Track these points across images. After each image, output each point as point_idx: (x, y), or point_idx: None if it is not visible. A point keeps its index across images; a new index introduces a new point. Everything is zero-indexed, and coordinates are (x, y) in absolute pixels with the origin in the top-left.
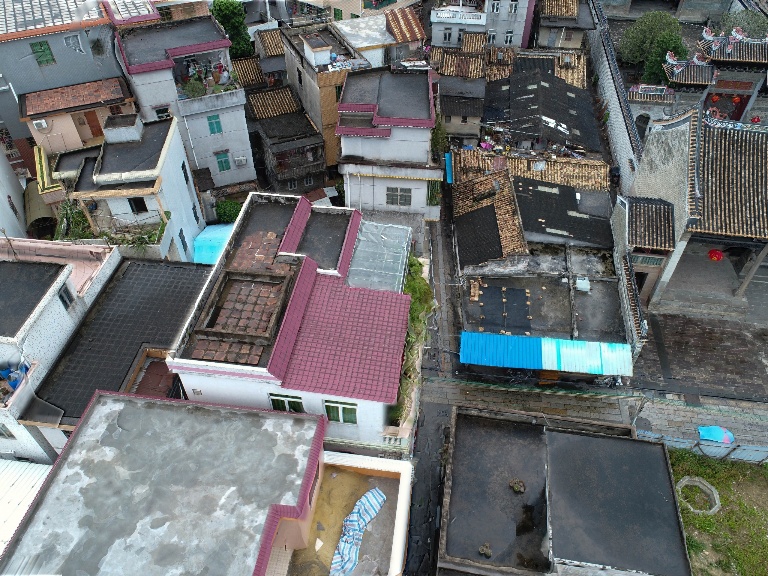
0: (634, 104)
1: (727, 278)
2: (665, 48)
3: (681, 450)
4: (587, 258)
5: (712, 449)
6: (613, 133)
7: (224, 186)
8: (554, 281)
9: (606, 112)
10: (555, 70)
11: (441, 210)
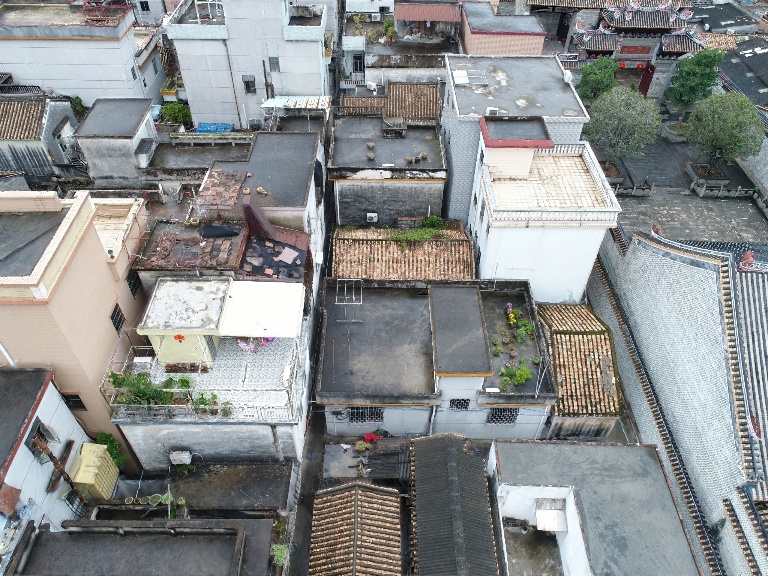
0: None
1: None
2: None
3: None
4: None
5: None
6: None
7: None
8: None
9: None
10: None
11: None
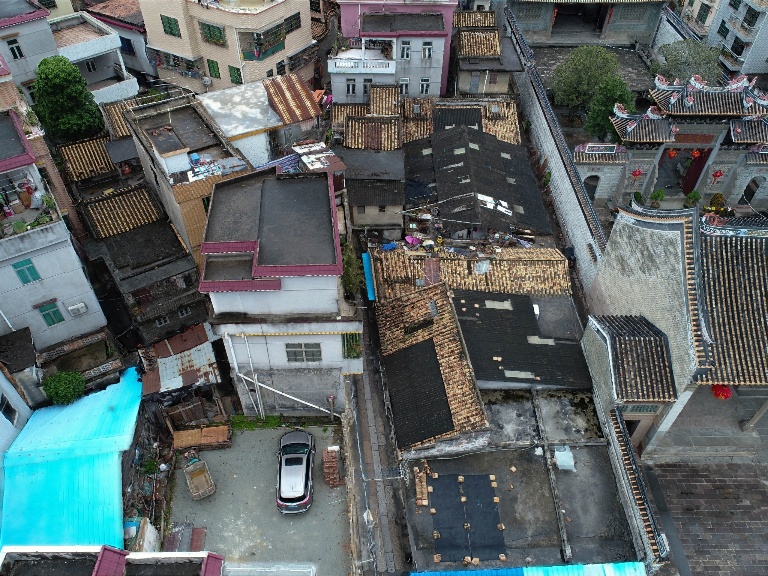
0: (581, 165)
1: (728, 402)
2: (609, 96)
3: None
4: (561, 408)
5: None
6: (559, 200)
7: (58, 344)
8: (525, 455)
9: (547, 171)
10: (482, 123)
11: (364, 330)
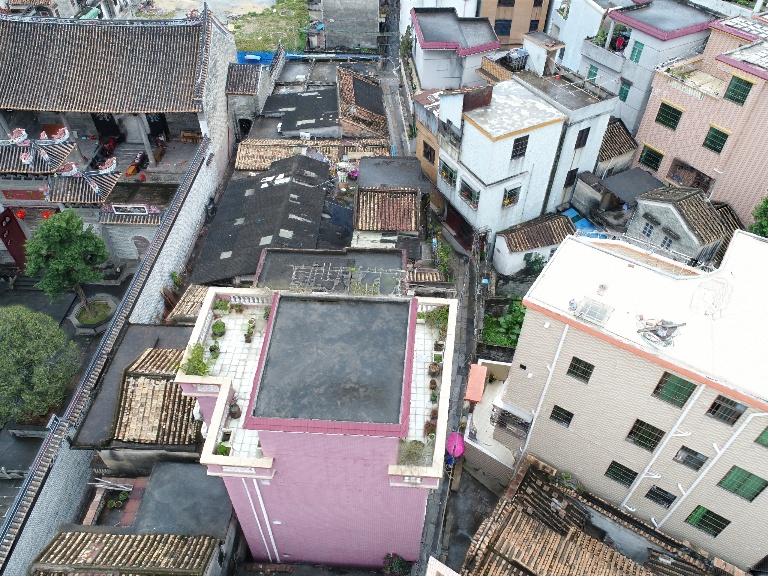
0: None
1: None
2: None
3: None
4: None
5: None
6: None
7: None
8: None
9: None
10: None
11: None
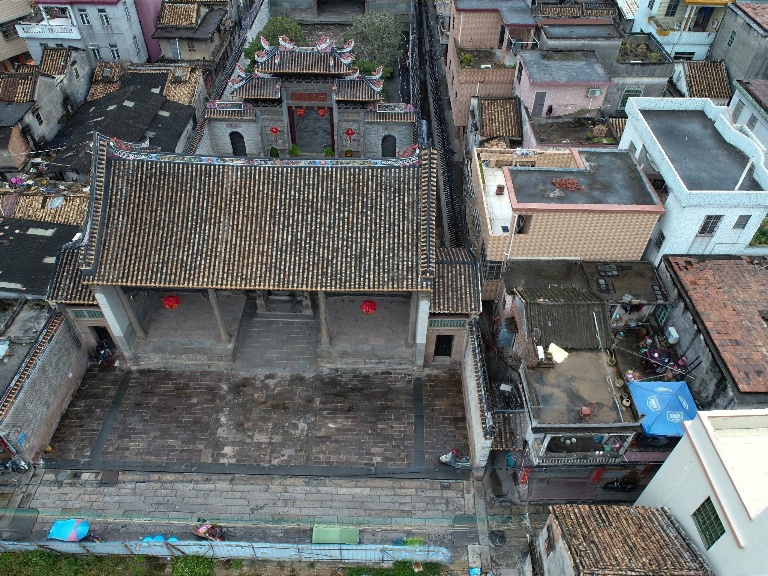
0: (218, 122)
1: (227, 320)
2: None
3: (29, 553)
4: (37, 314)
5: (64, 548)
6: None
7: None
8: None
9: None
10: (165, 85)
11: None
